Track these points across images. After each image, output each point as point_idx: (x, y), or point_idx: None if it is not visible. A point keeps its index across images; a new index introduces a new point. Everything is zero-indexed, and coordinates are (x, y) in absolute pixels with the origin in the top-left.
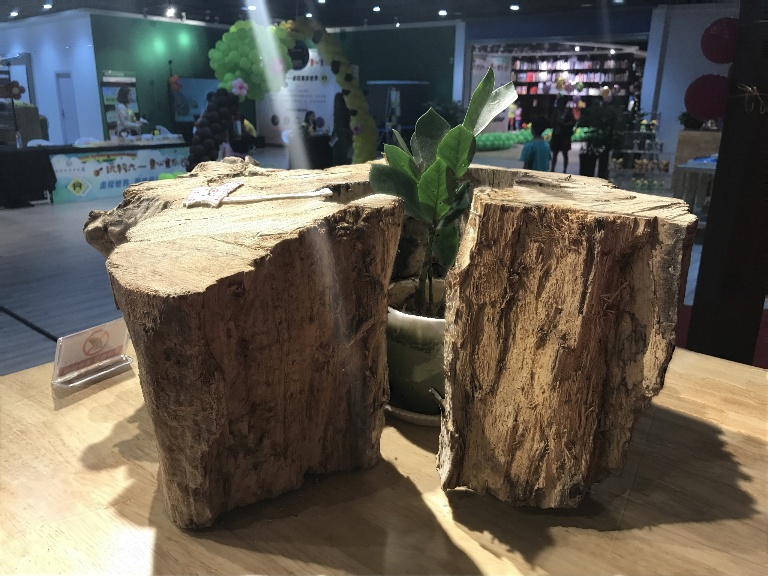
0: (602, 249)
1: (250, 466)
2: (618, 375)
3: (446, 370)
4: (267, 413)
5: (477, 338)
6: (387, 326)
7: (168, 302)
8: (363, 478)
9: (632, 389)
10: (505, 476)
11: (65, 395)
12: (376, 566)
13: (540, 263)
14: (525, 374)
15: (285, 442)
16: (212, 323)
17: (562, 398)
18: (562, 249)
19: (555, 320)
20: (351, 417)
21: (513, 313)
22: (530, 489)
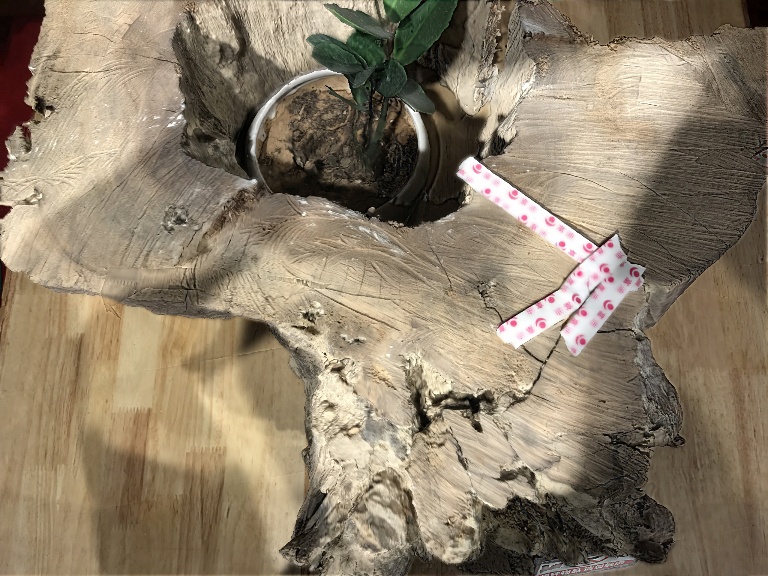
0: None
1: None
2: None
3: None
4: None
5: None
6: None
7: None
8: None
9: None
10: None
11: None
12: None
13: None
14: None
15: None
16: None
17: None
18: None
19: None
20: None
21: None
22: None
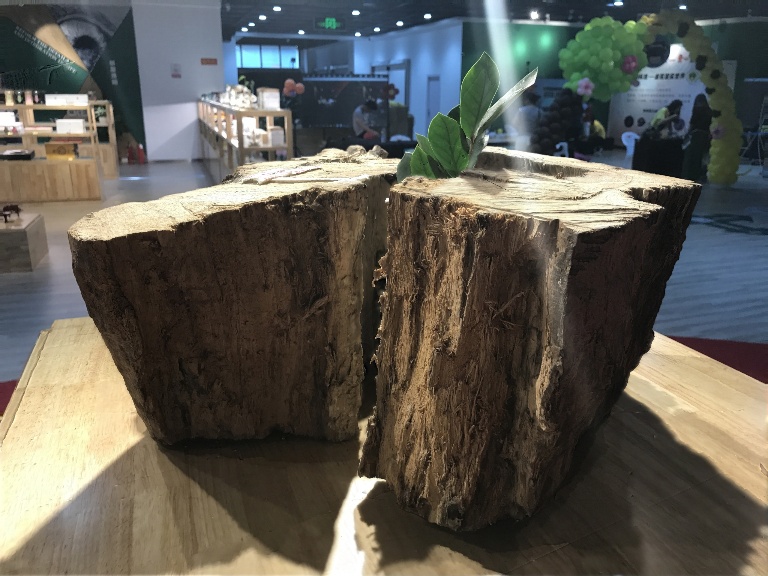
0: (484, 249)
1: (206, 404)
2: (524, 399)
3: (375, 358)
4: (219, 362)
5: (398, 330)
6: None
7: (80, 245)
8: (323, 448)
9: (533, 418)
10: (399, 476)
11: None
12: (254, 517)
13: (435, 258)
14: (423, 375)
15: (242, 392)
16: (124, 268)
17: (440, 406)
18: (450, 245)
19: (447, 322)
20: (317, 388)
21: (422, 309)
22: (415, 496)
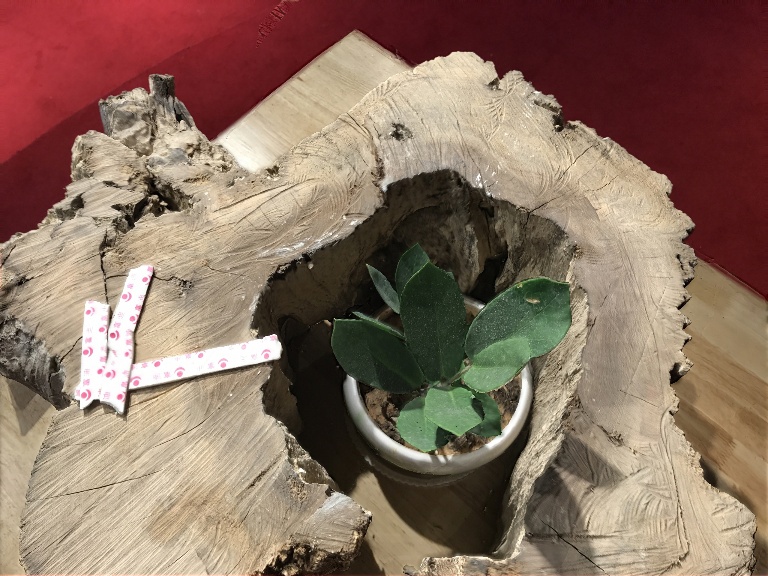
0: None
1: None
2: None
3: None
4: None
5: None
6: (364, 437)
7: None
8: (340, 572)
9: None
10: None
11: (25, 401)
12: None
13: None
14: None
15: None
16: None
17: None
18: None
19: None
20: None
21: None
22: None
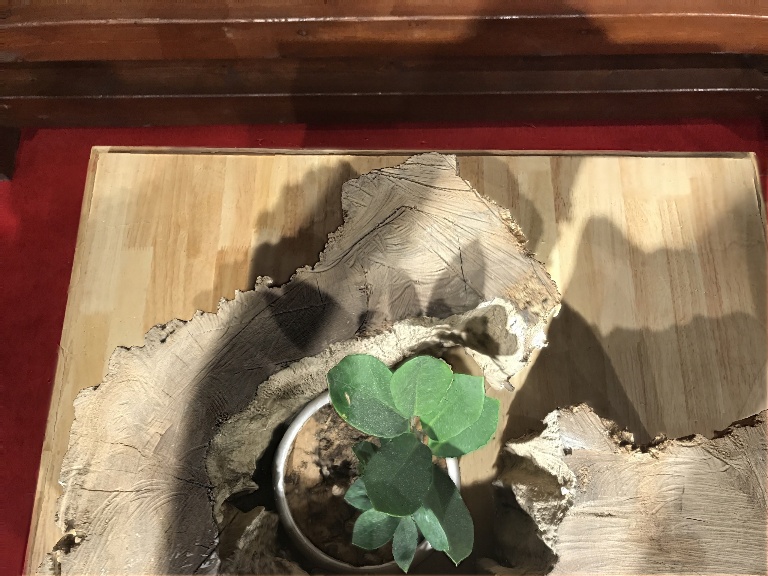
0: None
1: None
2: None
3: None
4: None
5: None
6: None
7: None
8: None
9: None
10: None
11: None
12: (600, 367)
13: None
14: None
15: None
16: None
17: None
18: None
19: None
20: None
21: None
22: None
